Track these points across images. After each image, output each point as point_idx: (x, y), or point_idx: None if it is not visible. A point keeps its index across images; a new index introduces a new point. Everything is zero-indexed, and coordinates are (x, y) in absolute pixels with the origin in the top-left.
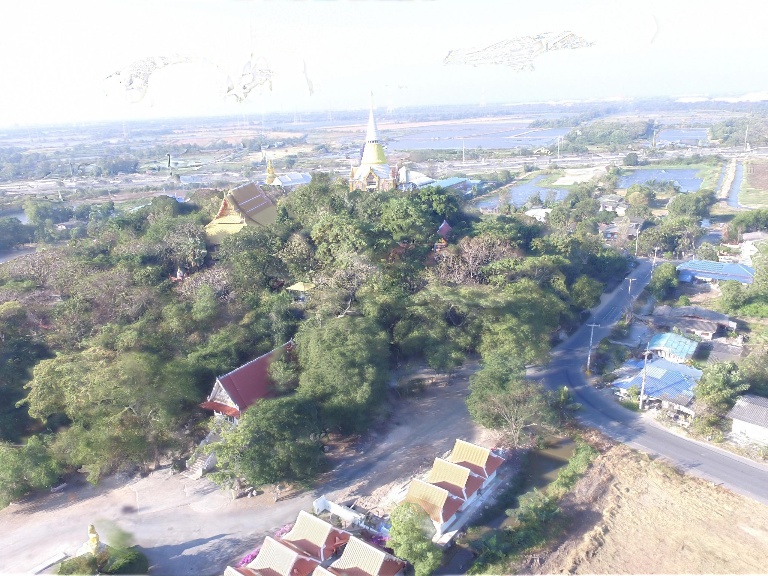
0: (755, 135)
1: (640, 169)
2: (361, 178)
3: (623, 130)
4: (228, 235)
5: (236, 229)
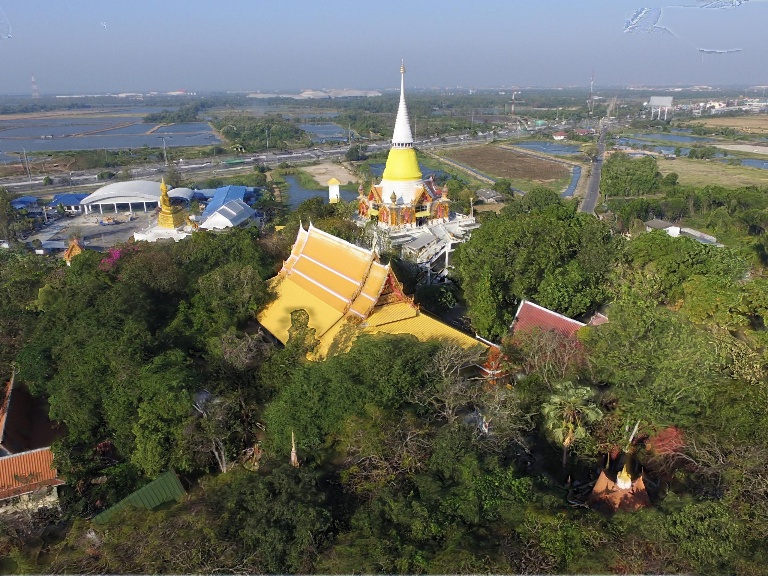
0: (424, 128)
1: (368, 164)
2: (404, 202)
3: (280, 124)
4: (619, 357)
5: (419, 330)
